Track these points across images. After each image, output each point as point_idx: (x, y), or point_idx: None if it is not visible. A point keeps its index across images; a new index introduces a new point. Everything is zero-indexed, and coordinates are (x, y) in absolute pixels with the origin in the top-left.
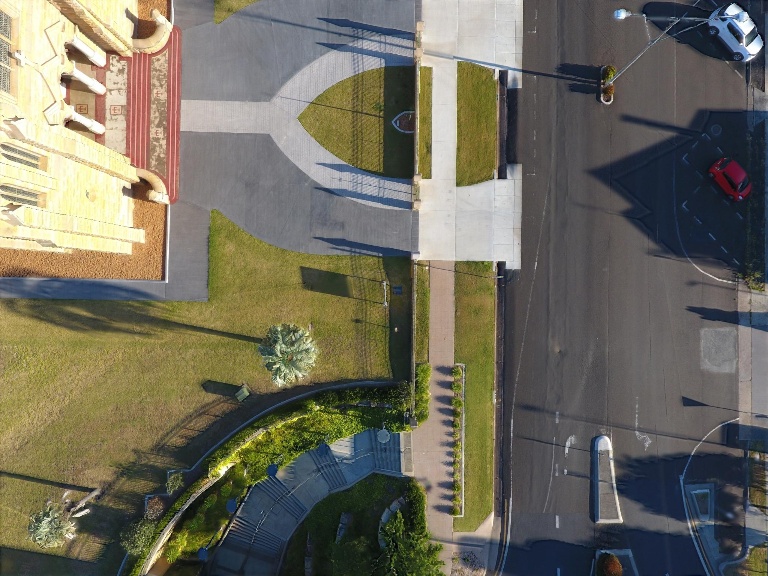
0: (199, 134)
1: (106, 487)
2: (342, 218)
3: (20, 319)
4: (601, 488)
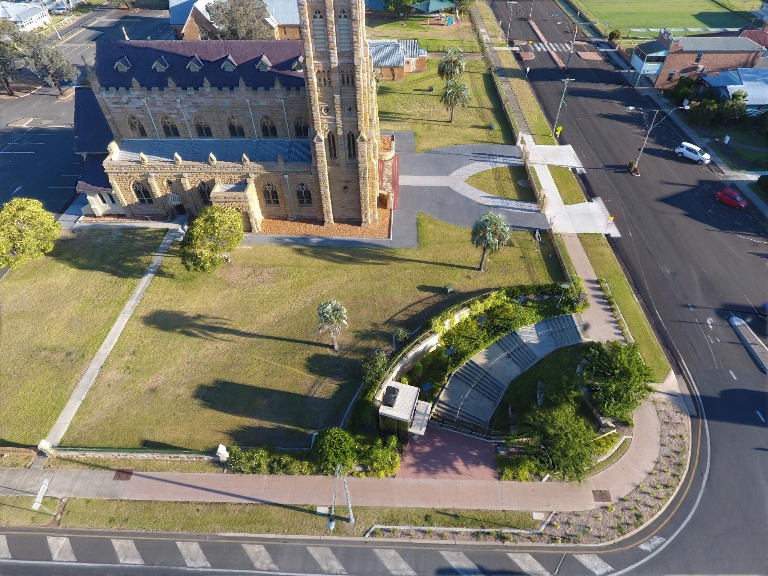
0: (409, 186)
1: (343, 344)
2: None
3: (294, 255)
4: (755, 349)
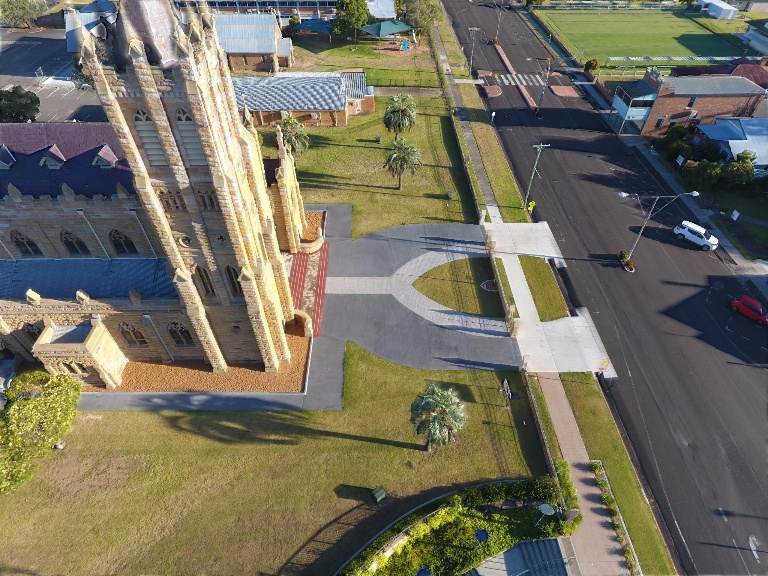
0: (339, 295)
1: None
2: (454, 344)
3: (161, 429)
4: None
